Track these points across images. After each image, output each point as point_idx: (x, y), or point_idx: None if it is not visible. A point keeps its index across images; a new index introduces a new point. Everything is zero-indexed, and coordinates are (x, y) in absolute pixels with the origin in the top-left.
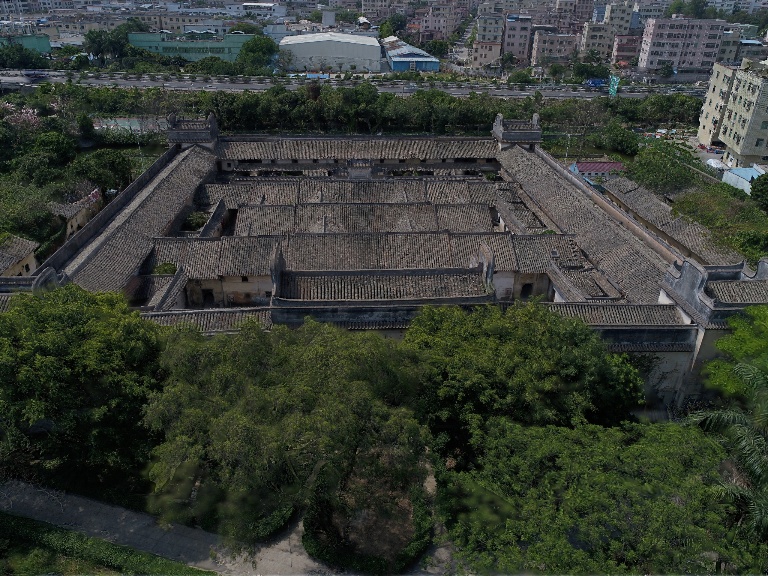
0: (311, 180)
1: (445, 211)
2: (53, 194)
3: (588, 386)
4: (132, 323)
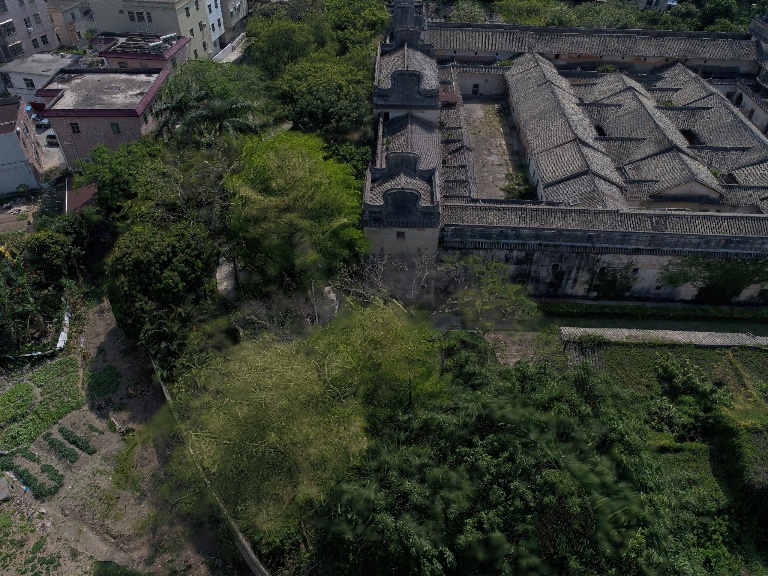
0: (720, 98)
1: (668, 157)
2: (623, 25)
3: (296, 112)
4: (347, 15)
